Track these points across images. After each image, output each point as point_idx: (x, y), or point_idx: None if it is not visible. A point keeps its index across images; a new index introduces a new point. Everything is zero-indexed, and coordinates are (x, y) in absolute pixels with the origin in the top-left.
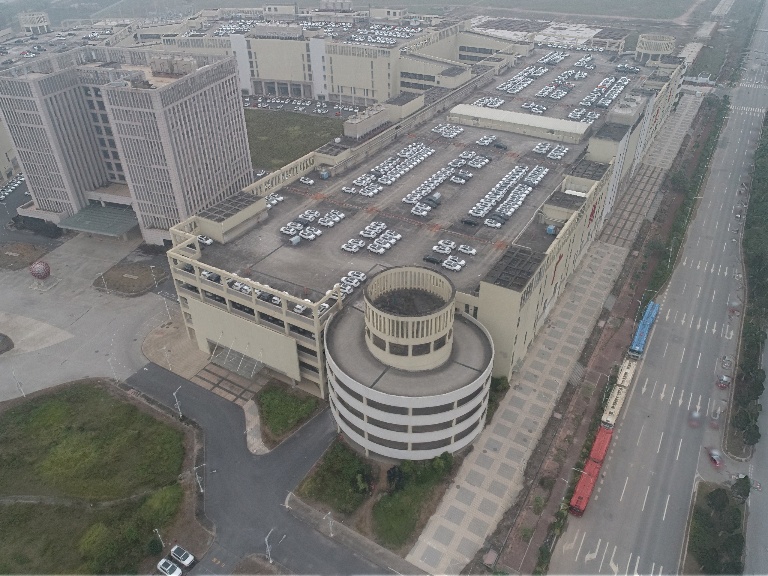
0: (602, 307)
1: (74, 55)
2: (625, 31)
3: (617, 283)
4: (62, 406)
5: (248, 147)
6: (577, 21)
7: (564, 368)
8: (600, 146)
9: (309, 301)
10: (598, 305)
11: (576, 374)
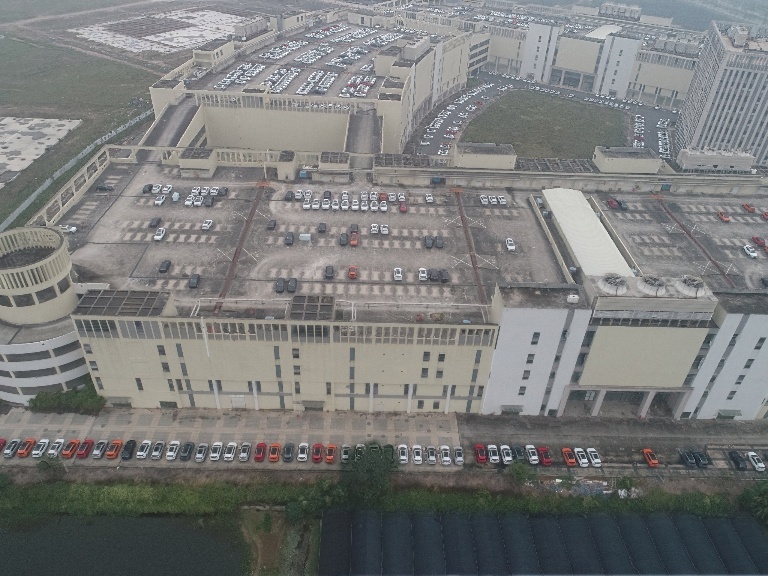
0: None
1: None
2: (219, 7)
3: None
4: None
5: None
6: (159, 10)
7: None
8: None
9: None
10: None
11: None
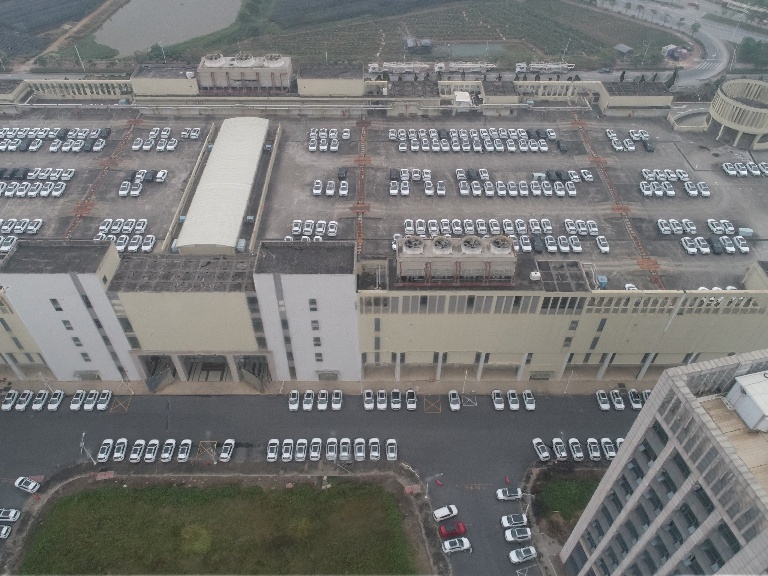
0: None
1: None
2: None
3: None
4: None
5: None
6: None
7: None
8: None
9: None
10: None
11: None
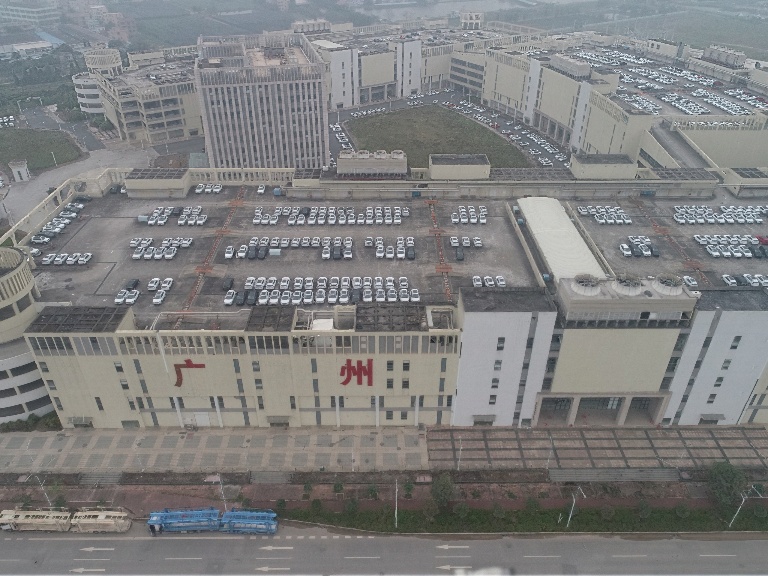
0: (249, 470)
1: (284, 38)
2: None
3: (322, 474)
4: (5, 243)
5: (328, 152)
6: None
7: (106, 464)
8: (460, 305)
9: (34, 251)
10: (253, 465)
11: (100, 478)
